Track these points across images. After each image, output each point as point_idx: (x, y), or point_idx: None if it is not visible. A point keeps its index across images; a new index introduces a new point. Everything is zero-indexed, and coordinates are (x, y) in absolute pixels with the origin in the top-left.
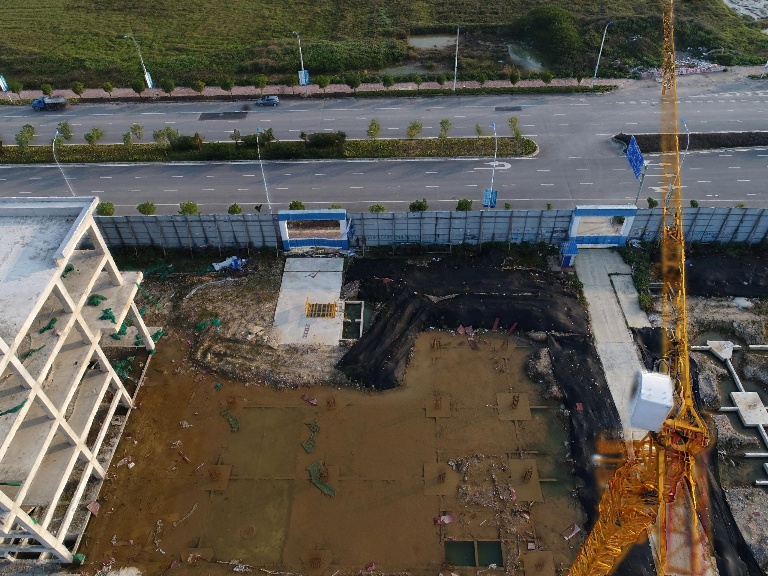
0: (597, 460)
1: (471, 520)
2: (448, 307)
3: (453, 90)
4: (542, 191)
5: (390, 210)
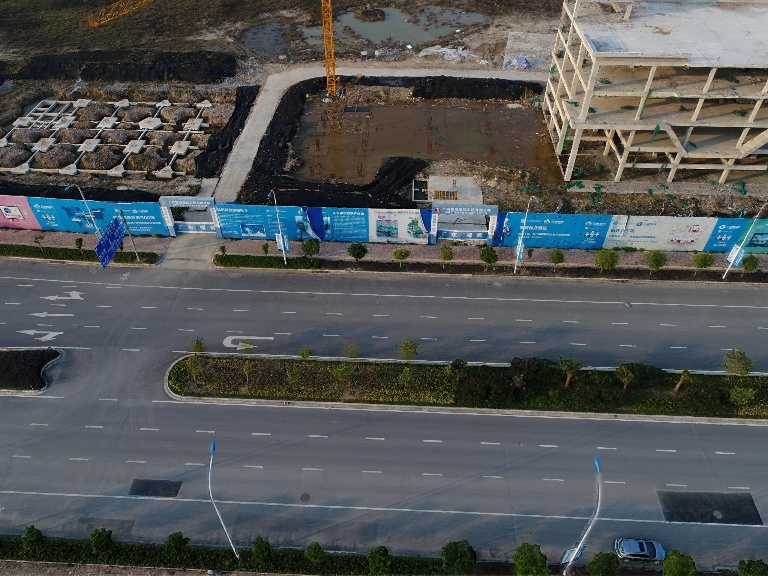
0: (284, 128)
1: (356, 116)
2: (347, 185)
3: (236, 571)
4: (208, 299)
5: (388, 284)
